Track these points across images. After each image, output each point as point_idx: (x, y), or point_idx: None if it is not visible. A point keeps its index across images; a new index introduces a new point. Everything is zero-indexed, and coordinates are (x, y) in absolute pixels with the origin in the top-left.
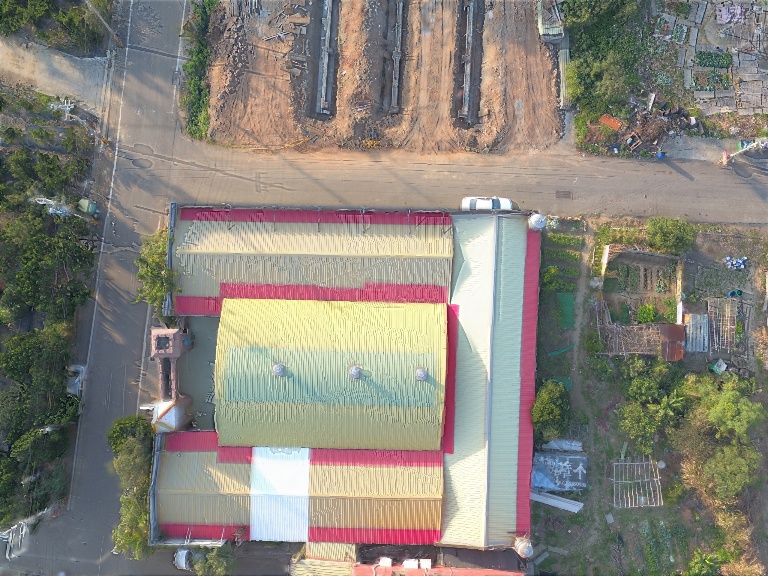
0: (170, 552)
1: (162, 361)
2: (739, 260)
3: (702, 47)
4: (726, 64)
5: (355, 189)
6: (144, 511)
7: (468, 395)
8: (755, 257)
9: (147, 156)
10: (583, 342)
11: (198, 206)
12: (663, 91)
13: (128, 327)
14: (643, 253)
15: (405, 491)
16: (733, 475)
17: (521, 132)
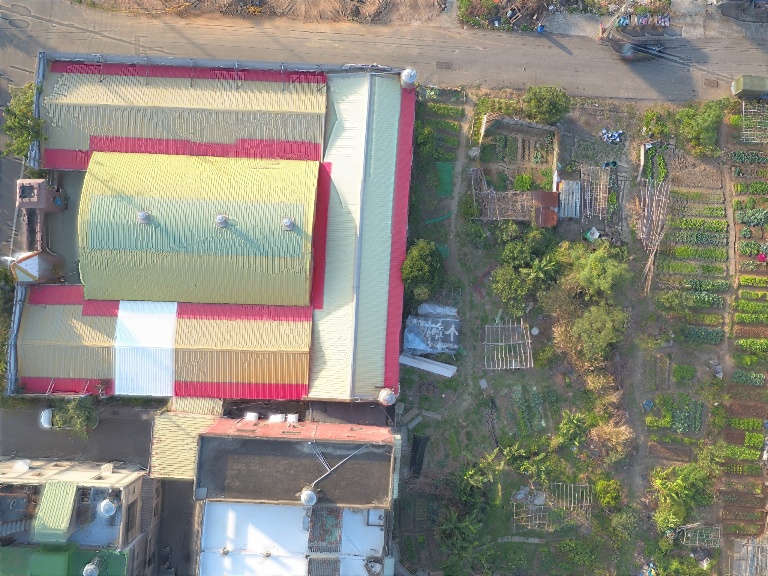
0: (38, 412)
1: (28, 212)
2: (615, 133)
3: None
4: None
5: (236, 55)
6: (4, 359)
7: (338, 251)
8: (631, 131)
9: (24, 17)
10: (461, 210)
11: (69, 59)
12: None
13: (0, 187)
14: (521, 124)
15: (271, 342)
16: (598, 333)
17: (403, 3)
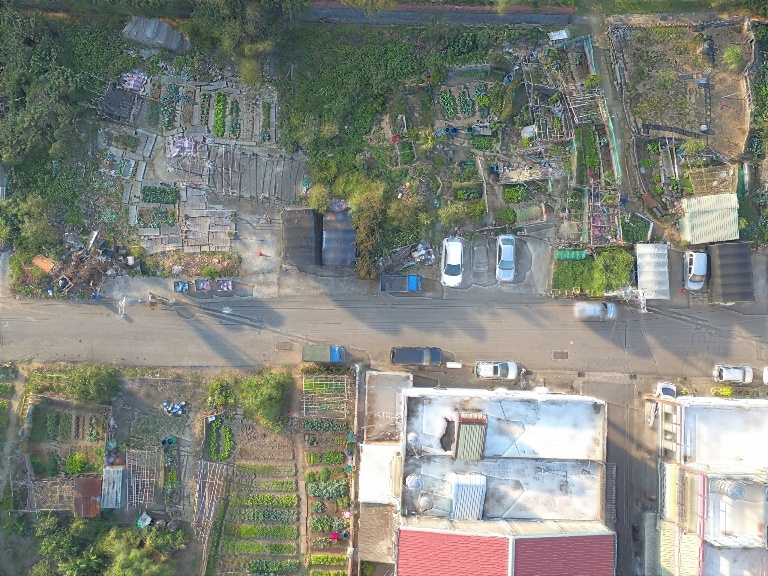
0: None
1: None
2: (176, 406)
3: (148, 182)
4: (171, 200)
5: None
6: None
7: None
8: (196, 401)
9: None
10: None
11: None
12: (106, 228)
13: None
14: None
15: None
16: None
17: None
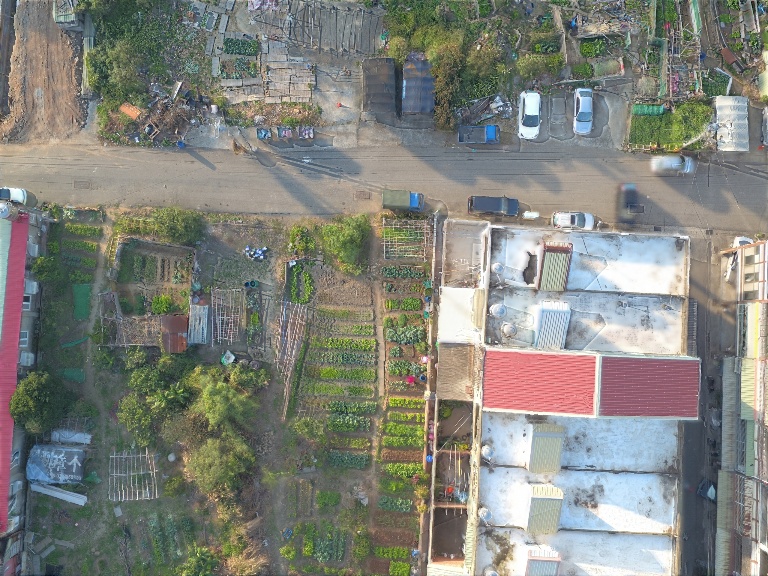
0: None
1: None
2: (258, 251)
3: (231, 34)
4: (253, 51)
5: None
6: None
7: None
8: (277, 248)
9: None
10: None
11: None
12: (190, 79)
13: None
14: (159, 244)
15: None
16: None
17: (41, 121)
